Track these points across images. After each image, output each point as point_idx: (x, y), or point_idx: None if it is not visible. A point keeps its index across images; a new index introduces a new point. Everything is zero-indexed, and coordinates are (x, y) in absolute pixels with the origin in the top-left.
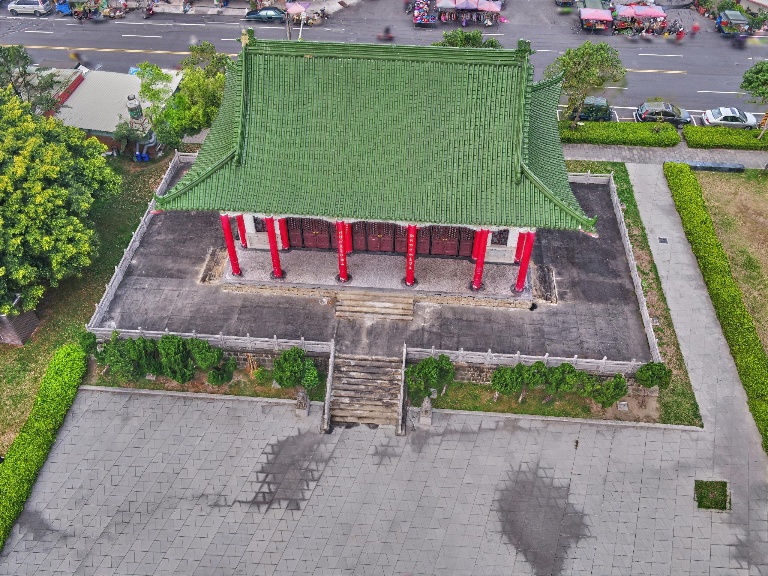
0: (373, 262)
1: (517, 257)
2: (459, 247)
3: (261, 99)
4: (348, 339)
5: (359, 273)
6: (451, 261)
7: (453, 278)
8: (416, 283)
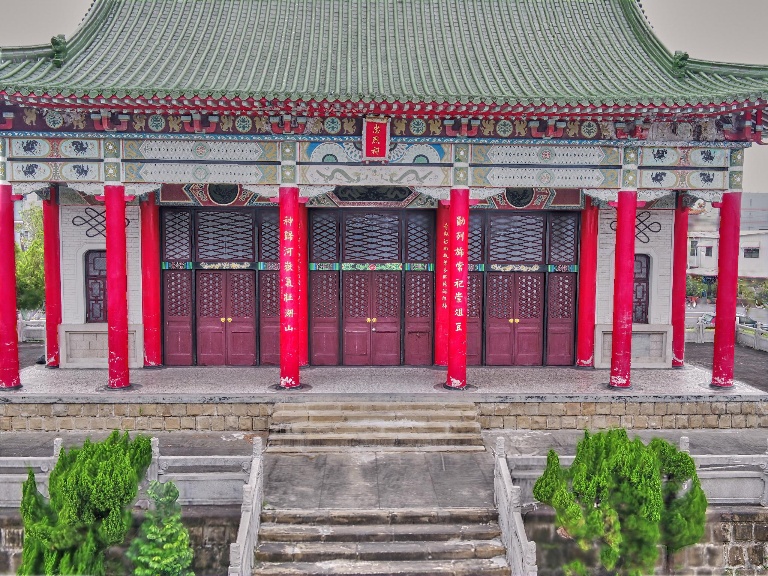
0: (358, 373)
1: (676, 351)
2: (546, 339)
3: (139, 8)
4: (306, 483)
5: (327, 381)
6: (535, 369)
7: (555, 381)
8: (472, 387)
